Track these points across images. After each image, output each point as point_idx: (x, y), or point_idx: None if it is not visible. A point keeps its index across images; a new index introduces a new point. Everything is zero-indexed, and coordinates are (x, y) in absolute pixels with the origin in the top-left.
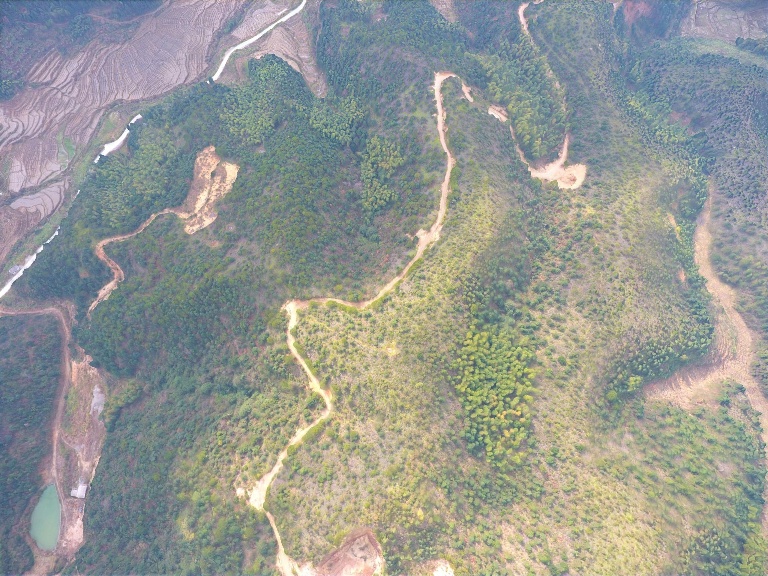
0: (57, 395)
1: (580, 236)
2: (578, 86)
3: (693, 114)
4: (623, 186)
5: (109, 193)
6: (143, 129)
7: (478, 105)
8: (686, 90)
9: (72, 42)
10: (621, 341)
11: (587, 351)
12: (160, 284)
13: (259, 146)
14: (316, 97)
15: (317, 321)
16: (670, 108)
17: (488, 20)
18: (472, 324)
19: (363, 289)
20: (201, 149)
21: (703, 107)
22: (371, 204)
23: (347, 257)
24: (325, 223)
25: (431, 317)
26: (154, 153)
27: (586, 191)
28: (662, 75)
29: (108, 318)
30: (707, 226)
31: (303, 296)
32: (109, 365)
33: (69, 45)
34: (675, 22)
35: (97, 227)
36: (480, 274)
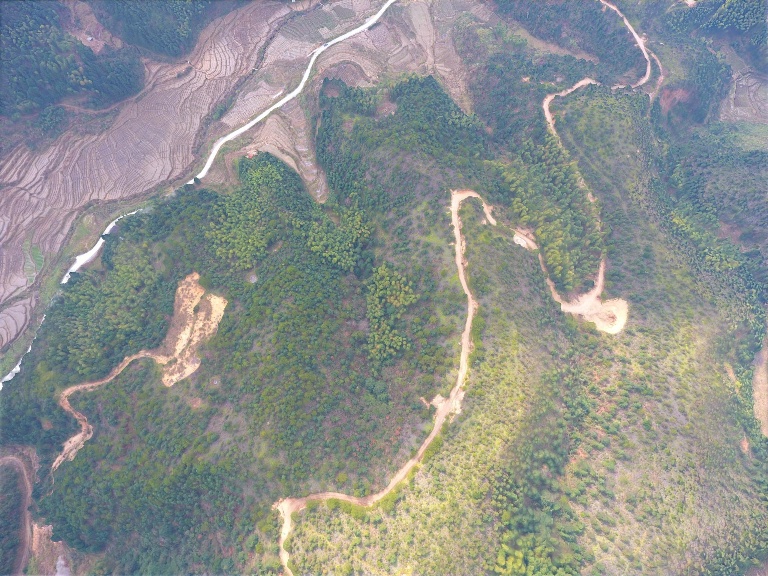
0: (15, 568)
1: (626, 403)
2: (615, 201)
3: (744, 228)
4: (674, 336)
5: (78, 325)
6: (118, 245)
7: (502, 231)
8: (736, 200)
9: (42, 136)
10: (684, 556)
11: (644, 574)
12: (131, 457)
13: (250, 271)
14: (315, 203)
15: (316, 532)
16: (717, 220)
17: (508, 112)
18: (504, 538)
19: (371, 479)
20: (183, 277)
21: (756, 221)
22: (379, 352)
23: (351, 424)
24: (325, 382)
25: (454, 535)
26: (130, 276)
27: (630, 339)
28: (706, 178)
29: (71, 491)
30: (766, 367)
31: (299, 495)
32: (73, 543)
33: (39, 139)
34: (714, 105)
35: (62, 371)
36: (512, 468)
